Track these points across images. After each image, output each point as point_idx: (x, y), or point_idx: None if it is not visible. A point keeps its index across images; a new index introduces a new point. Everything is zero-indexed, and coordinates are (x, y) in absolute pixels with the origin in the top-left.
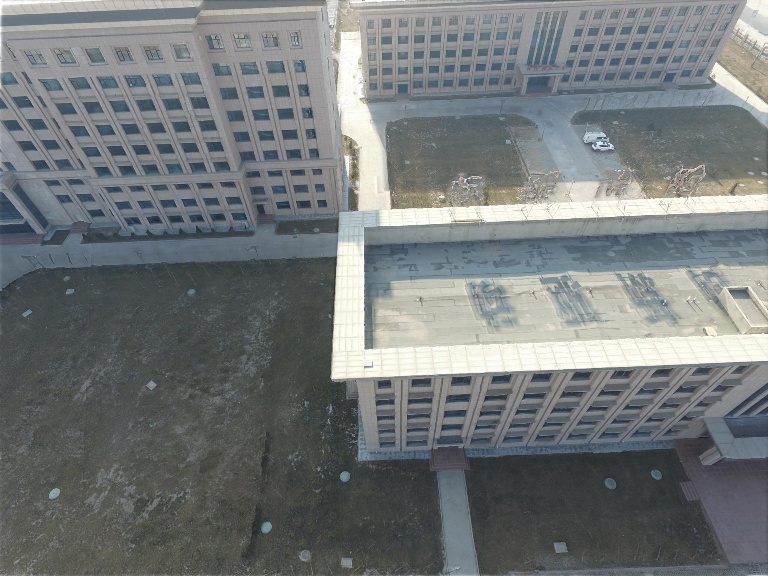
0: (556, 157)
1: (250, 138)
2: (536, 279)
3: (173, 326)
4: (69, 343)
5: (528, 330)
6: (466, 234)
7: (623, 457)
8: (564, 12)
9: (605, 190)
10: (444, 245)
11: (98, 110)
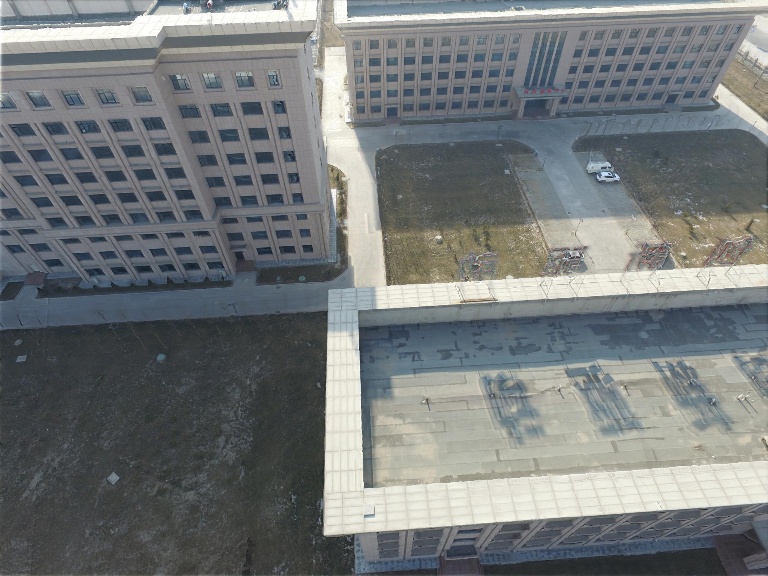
0: (559, 189)
1: (225, 183)
2: (561, 370)
3: (140, 401)
4: (18, 425)
5: (557, 442)
6: (477, 313)
7: (657, 559)
8: (563, 32)
9: (613, 227)
10: (451, 325)
11: (47, 158)
